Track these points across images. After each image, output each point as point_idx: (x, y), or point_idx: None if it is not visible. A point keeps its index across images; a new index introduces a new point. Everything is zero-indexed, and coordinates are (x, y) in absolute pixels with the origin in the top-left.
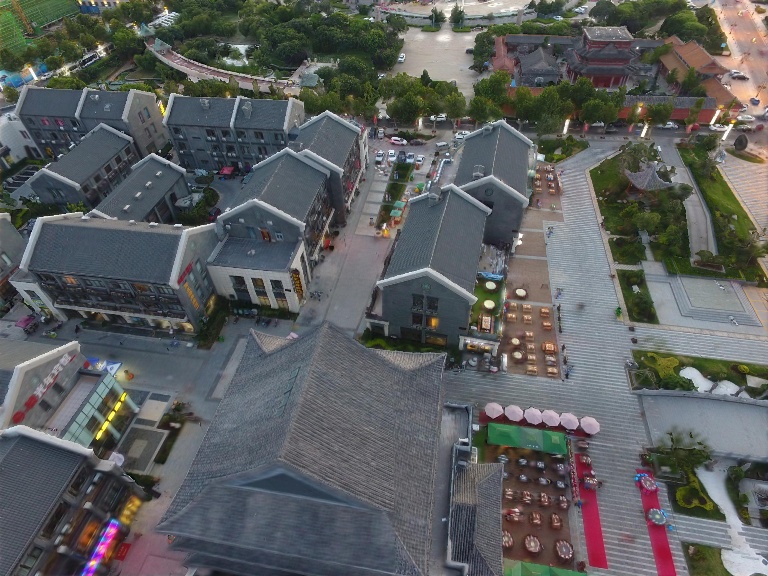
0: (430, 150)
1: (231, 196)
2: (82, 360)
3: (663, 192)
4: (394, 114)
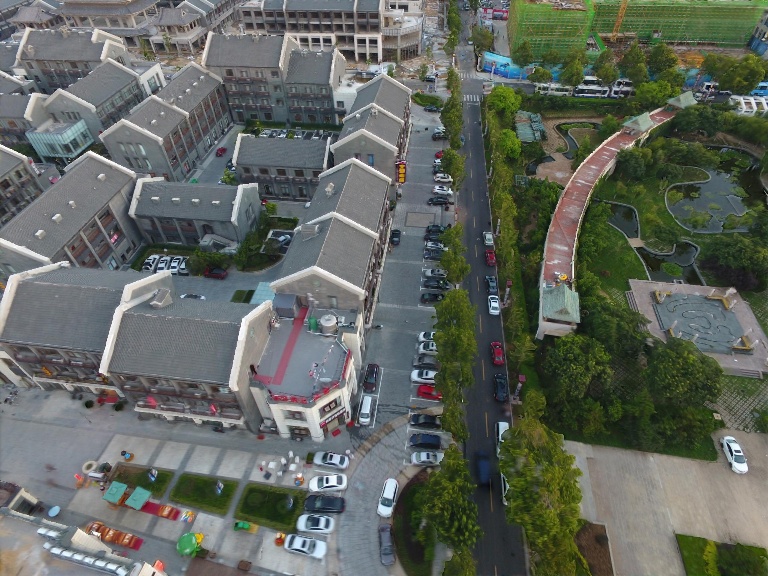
0: (356, 575)
1: (258, 281)
2: None
3: None
4: (443, 471)
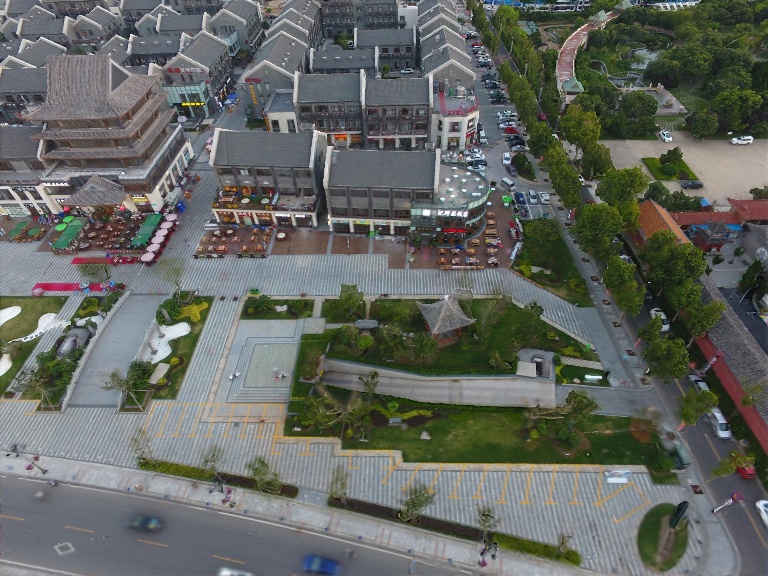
0: None
1: None
2: (207, 78)
3: (468, 362)
4: None
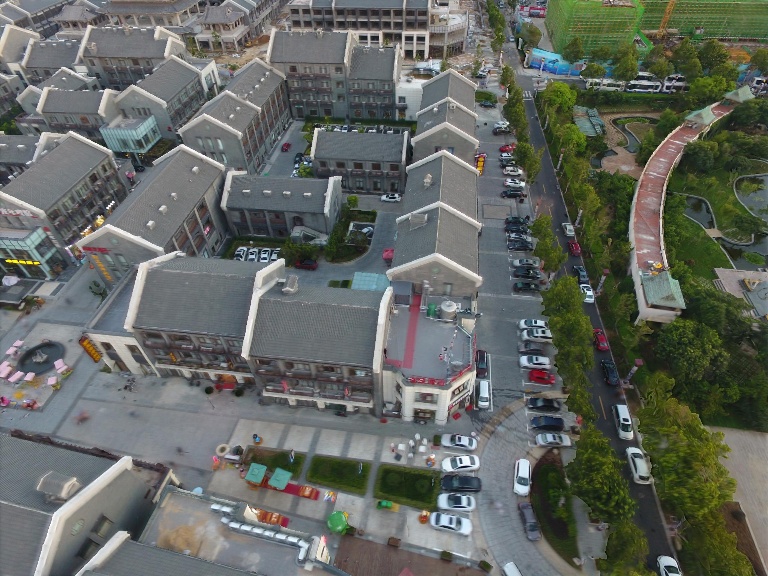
0: (505, 550)
1: (348, 272)
2: (44, 224)
3: None
4: None
